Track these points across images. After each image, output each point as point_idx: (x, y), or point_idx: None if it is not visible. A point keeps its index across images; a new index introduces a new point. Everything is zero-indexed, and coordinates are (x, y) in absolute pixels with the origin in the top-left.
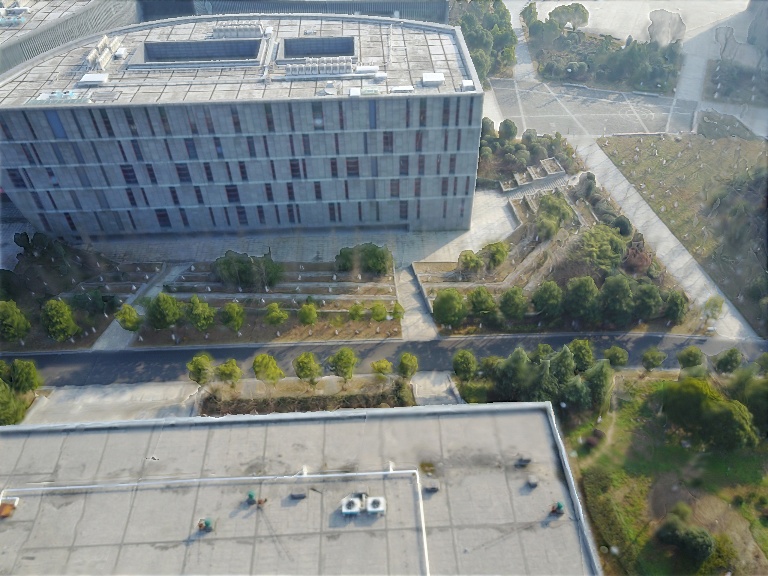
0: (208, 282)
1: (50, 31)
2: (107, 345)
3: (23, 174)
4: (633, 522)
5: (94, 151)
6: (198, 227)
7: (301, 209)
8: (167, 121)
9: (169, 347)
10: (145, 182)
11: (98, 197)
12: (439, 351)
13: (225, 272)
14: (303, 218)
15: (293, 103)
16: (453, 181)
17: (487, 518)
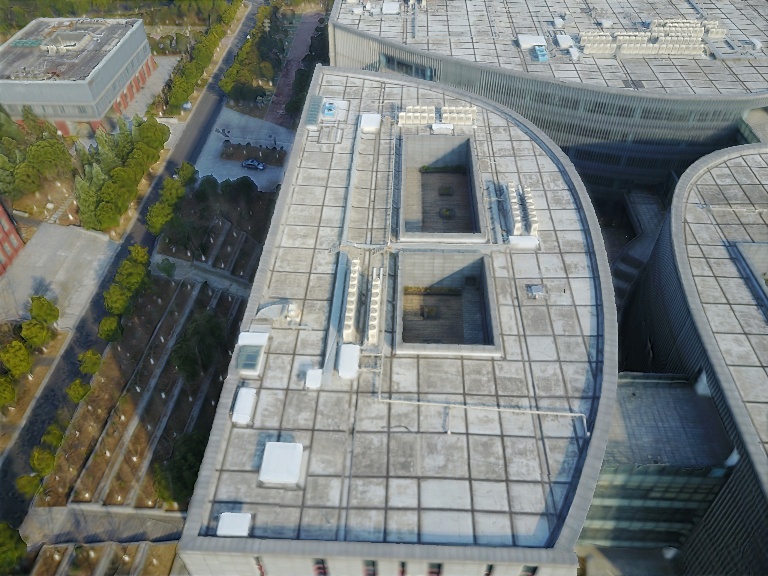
0: None
1: (523, 80)
2: (155, 262)
3: None
4: None
5: None
6: None
7: None
8: None
9: None
10: None
11: None
12: None
13: (193, 320)
14: None
15: None
16: None
17: None
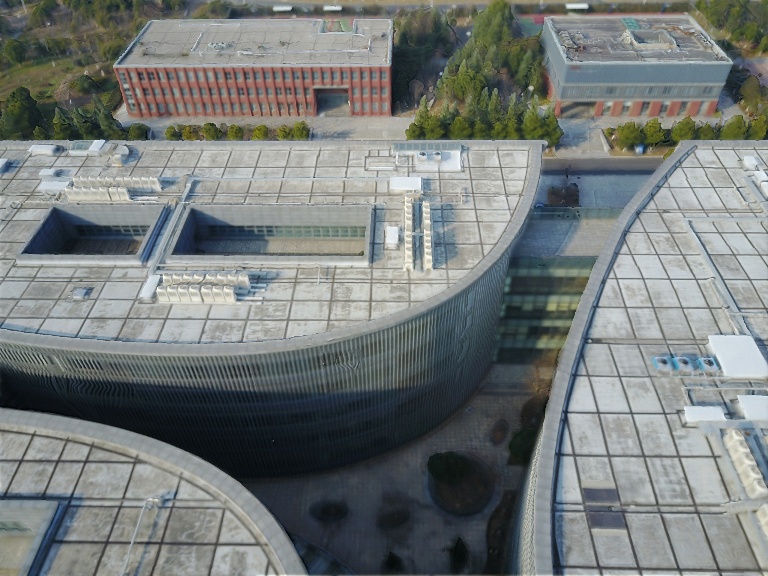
0: None
1: None
2: None
3: None
4: (103, 98)
5: None
6: None
7: None
8: None
9: None
10: None
11: None
12: None
13: None
14: None
15: None
16: None
17: (170, 45)
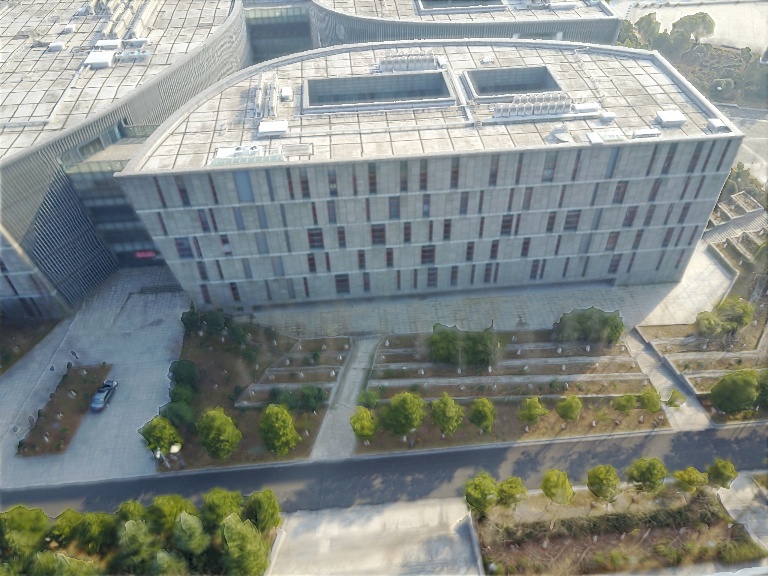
0: (417, 362)
1: (184, 66)
2: (328, 452)
3: (193, 243)
4: None
5: (281, 214)
6: (379, 291)
7: (501, 268)
8: (375, 178)
9: (404, 452)
10: (332, 246)
11: (273, 264)
12: (724, 444)
13: (444, 352)
14: (500, 277)
15: (525, 153)
16: (679, 231)
17: None
